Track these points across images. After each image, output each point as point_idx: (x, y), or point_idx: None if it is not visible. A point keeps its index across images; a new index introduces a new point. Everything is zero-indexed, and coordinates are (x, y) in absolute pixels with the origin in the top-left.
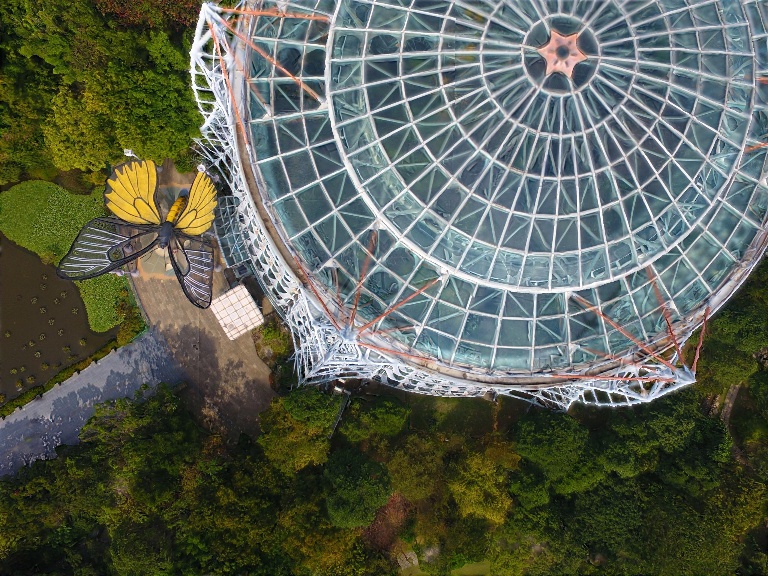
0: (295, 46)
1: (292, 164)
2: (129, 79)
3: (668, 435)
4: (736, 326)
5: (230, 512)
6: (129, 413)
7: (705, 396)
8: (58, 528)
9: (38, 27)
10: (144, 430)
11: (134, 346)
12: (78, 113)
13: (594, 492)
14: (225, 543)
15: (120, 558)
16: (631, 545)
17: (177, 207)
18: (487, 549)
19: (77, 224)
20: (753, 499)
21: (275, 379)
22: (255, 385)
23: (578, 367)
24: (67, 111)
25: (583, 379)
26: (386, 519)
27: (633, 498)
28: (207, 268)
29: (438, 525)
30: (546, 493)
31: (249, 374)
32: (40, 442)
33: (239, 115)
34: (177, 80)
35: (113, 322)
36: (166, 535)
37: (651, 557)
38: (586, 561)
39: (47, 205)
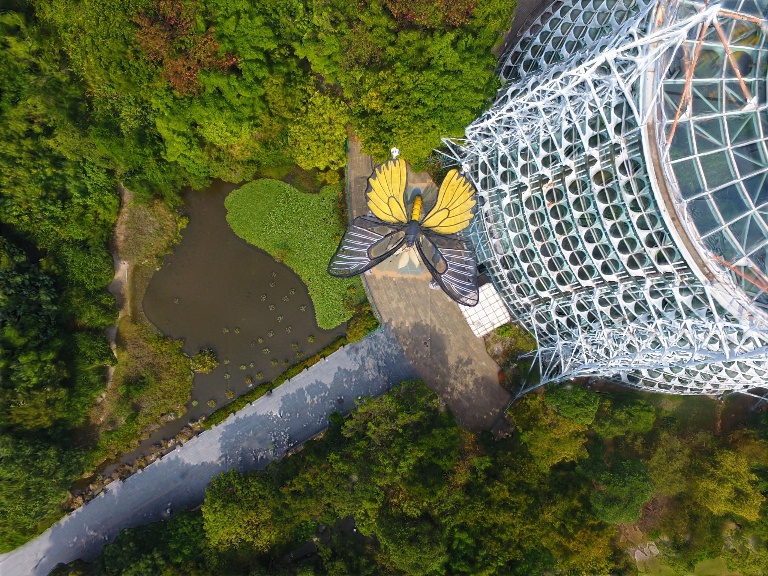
0: (714, 48)
1: (707, 164)
2: (410, 79)
3: None
4: None
5: (499, 507)
6: (394, 409)
7: None
8: (303, 522)
9: (309, 28)
10: (412, 426)
11: (361, 343)
12: (332, 113)
13: None
14: (495, 538)
15: (404, 552)
16: None
17: (419, 206)
18: (722, 546)
19: (306, 222)
20: None
21: (510, 376)
22: (484, 382)
23: None
24: (324, 111)
25: None
26: None
27: None
28: (469, 266)
29: (684, 522)
30: None
31: (478, 371)
32: (268, 437)
33: (650, 116)
34: (455, 80)
35: (340, 319)
36: (438, 529)
37: None
38: None
39: (277, 203)
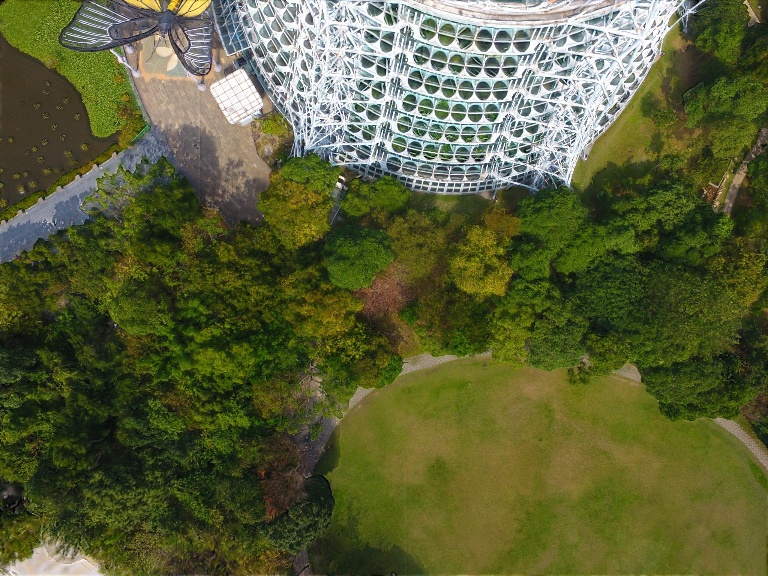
0: None
1: None
2: None
3: (668, 208)
4: (733, 88)
5: None
6: None
7: (705, 195)
8: (60, 316)
9: None
10: None
11: (135, 151)
12: None
13: (595, 270)
14: (226, 303)
15: (121, 307)
16: (633, 317)
17: None
18: (489, 337)
19: None
20: (755, 265)
21: (275, 172)
22: (255, 184)
23: (573, 2)
24: None
25: (578, 17)
26: (387, 317)
27: (634, 273)
28: (207, 40)
29: (439, 303)
30: (546, 259)
31: (249, 173)
32: None
33: None
34: None
35: (115, 127)
36: (167, 294)
37: (653, 320)
38: (588, 332)
39: (50, 12)
